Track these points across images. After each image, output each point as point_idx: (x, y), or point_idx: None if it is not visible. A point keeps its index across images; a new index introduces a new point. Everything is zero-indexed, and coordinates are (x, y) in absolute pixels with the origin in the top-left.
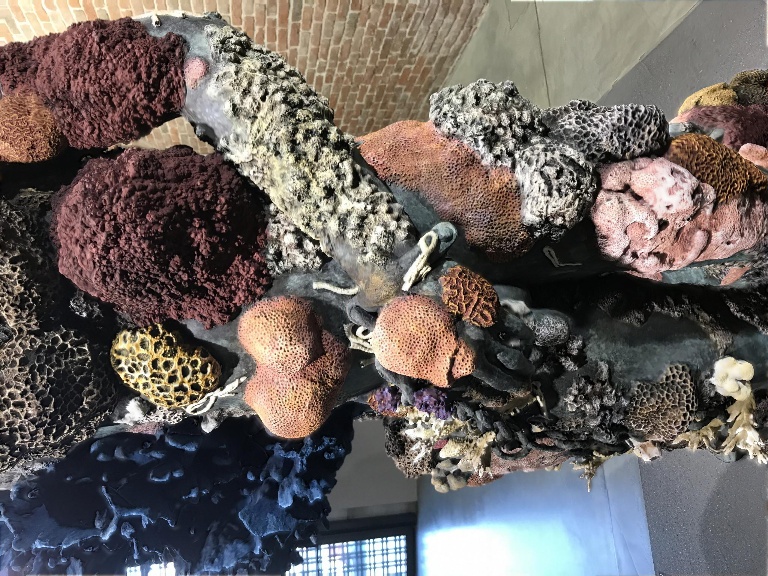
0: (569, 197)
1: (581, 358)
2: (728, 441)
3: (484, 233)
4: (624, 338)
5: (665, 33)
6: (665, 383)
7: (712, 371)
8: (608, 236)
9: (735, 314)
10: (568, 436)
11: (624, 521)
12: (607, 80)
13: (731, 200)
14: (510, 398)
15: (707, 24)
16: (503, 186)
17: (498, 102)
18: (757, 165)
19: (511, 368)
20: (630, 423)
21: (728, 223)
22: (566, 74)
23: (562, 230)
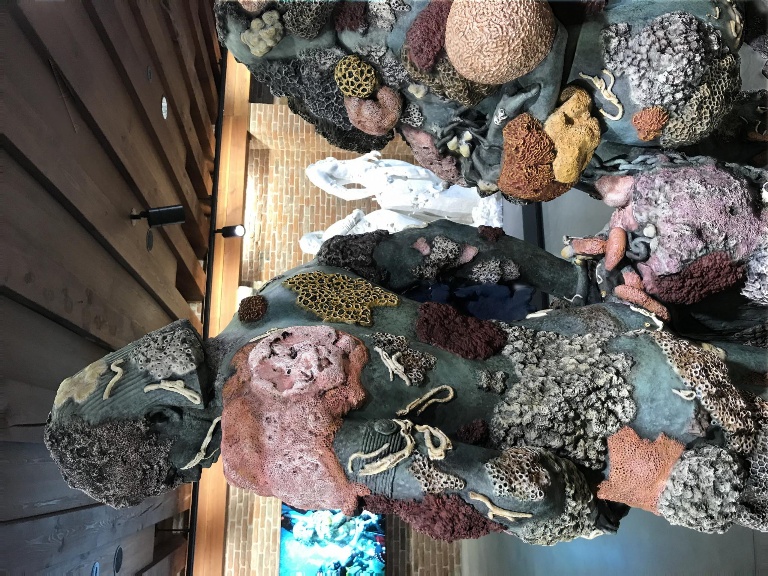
0: None
1: None
2: None
3: None
4: None
5: None
6: None
7: None
8: None
9: None
10: None
11: None
12: None
13: None
14: None
15: None
16: None
17: None
18: None
19: None
20: None
21: None
22: None
23: None
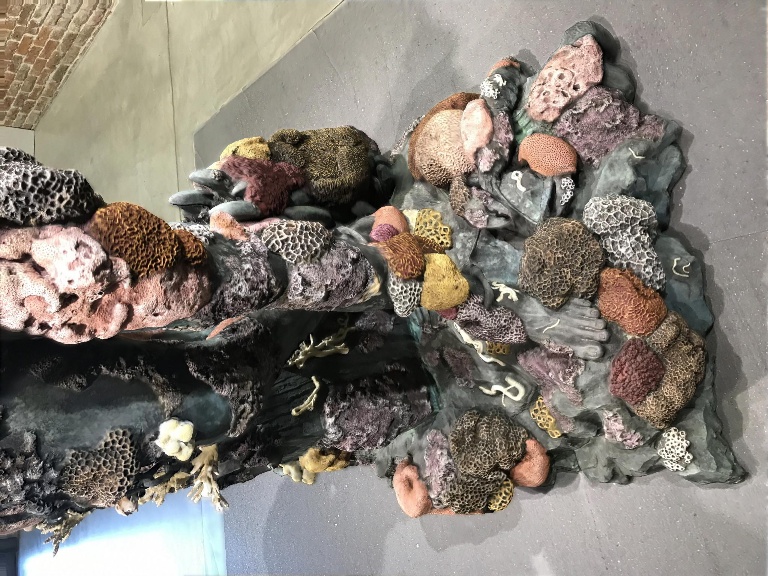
0: None
1: (2, 430)
2: (192, 491)
3: None
4: (60, 405)
5: (263, 71)
6: (104, 449)
7: (157, 433)
8: (1, 308)
9: (192, 374)
10: None
11: (213, 531)
12: (223, 101)
13: (153, 275)
14: None
15: (293, 72)
16: None
17: None
18: (219, 233)
19: None
20: (70, 491)
21: (150, 297)
22: (190, 85)
23: None
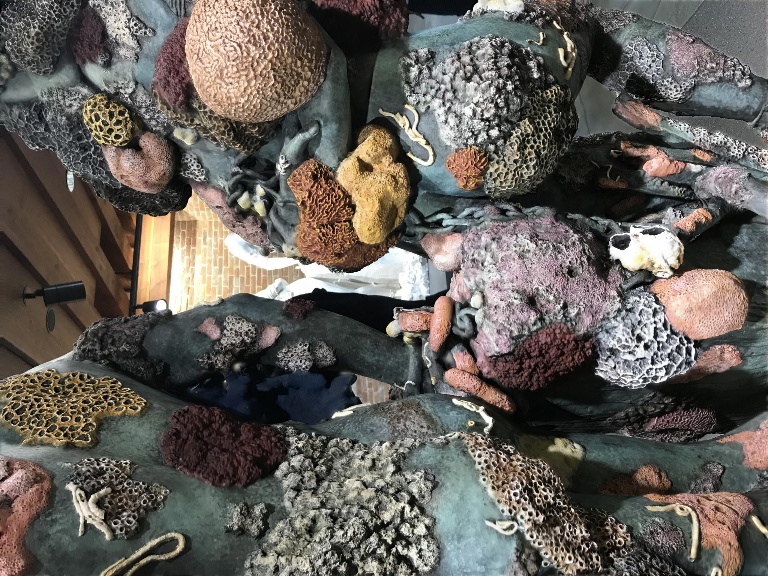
0: None
1: None
2: None
3: None
4: None
5: None
6: None
7: None
8: None
9: None
10: None
11: None
12: None
13: None
14: None
15: None
16: None
17: None
18: None
19: None
20: None
21: None
22: None
23: None
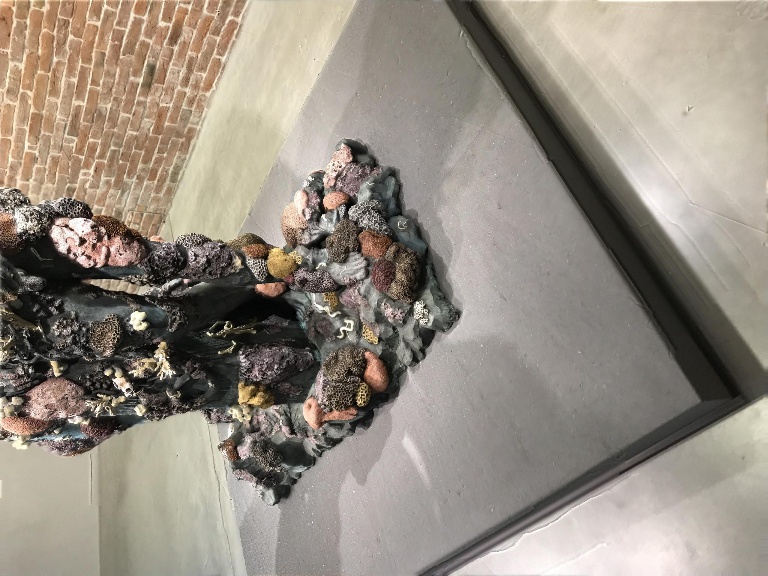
0: (35, 223)
1: (61, 309)
2: None
3: (0, 238)
4: (85, 303)
5: None
6: (105, 322)
7: (130, 319)
8: (58, 243)
9: (147, 301)
10: (59, 352)
11: None
12: None
13: (117, 236)
14: (7, 300)
15: None
16: (9, 220)
17: (10, 192)
18: None
19: (2, 277)
20: (92, 345)
21: (116, 245)
22: None
23: (34, 236)
